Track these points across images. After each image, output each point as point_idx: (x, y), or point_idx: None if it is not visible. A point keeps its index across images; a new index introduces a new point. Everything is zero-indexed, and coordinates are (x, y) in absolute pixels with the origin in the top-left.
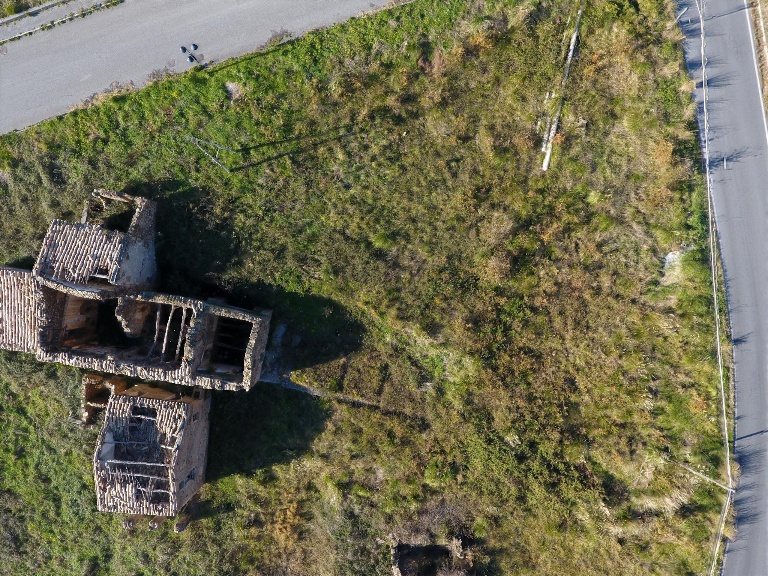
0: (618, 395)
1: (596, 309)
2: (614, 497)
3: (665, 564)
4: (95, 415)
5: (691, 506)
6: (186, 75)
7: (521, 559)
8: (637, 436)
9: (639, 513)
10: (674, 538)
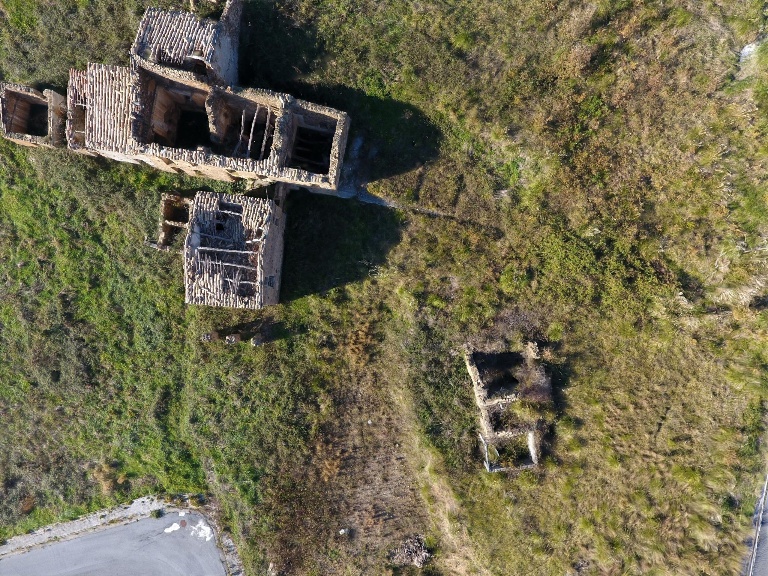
0: (693, 191)
1: (672, 106)
2: (690, 291)
3: (739, 359)
4: (171, 237)
5: (766, 298)
6: None
7: (595, 362)
8: (712, 232)
9: (714, 308)
10: (749, 332)
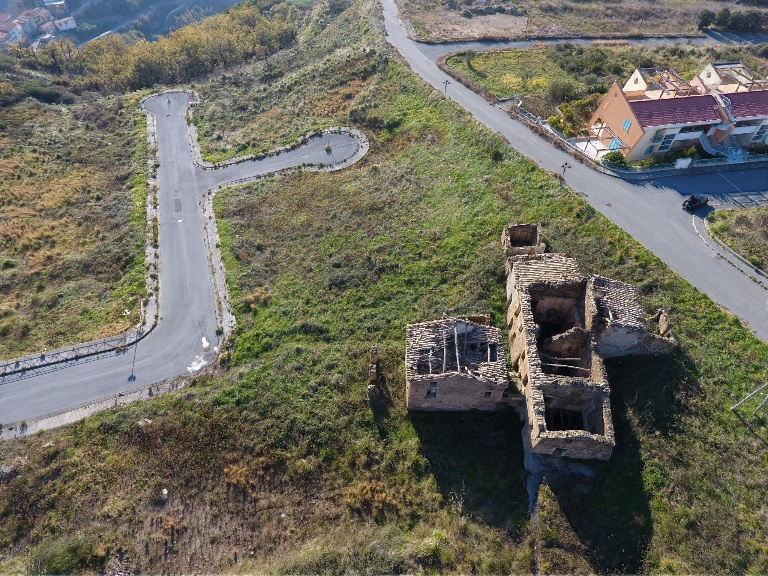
0: None
1: None
2: None
3: None
4: None
5: None
6: None
7: None
8: None
9: None
10: None
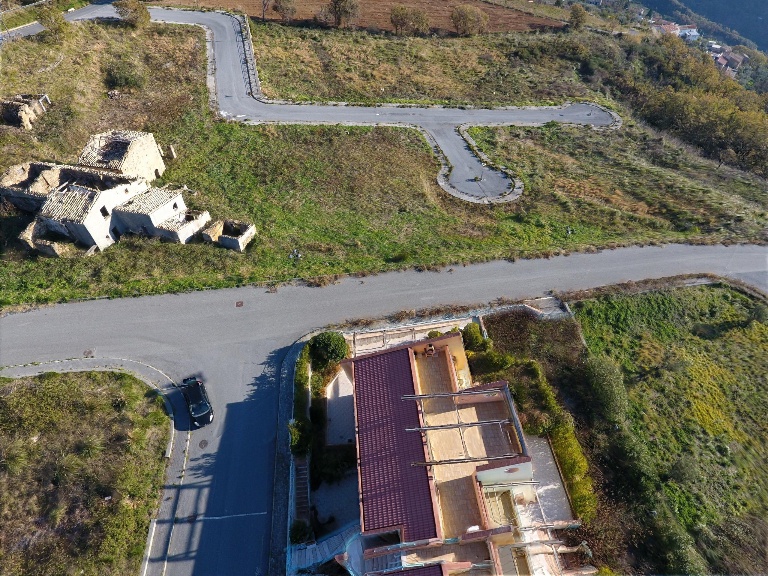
0: None
1: None
2: None
3: None
4: None
5: None
6: None
7: None
8: None
9: None
10: None
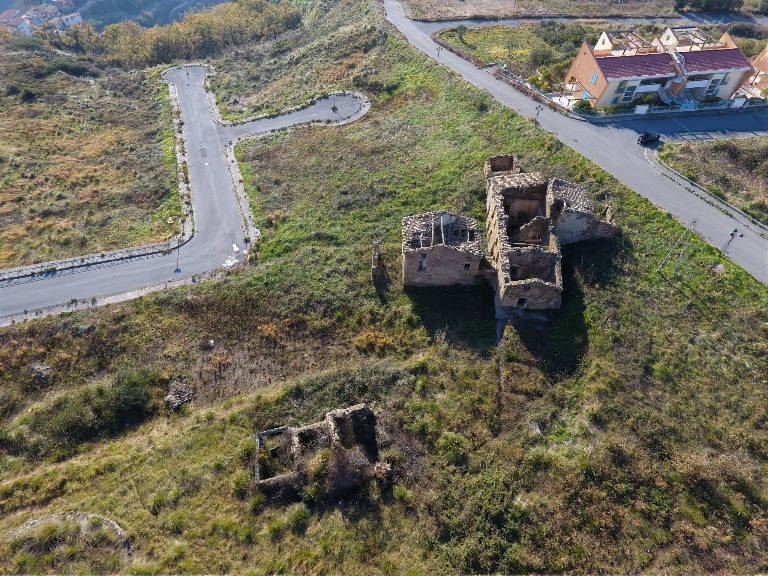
0: None
1: None
2: None
3: None
4: None
5: None
6: (709, 245)
7: (372, 543)
8: None
9: None
10: None
